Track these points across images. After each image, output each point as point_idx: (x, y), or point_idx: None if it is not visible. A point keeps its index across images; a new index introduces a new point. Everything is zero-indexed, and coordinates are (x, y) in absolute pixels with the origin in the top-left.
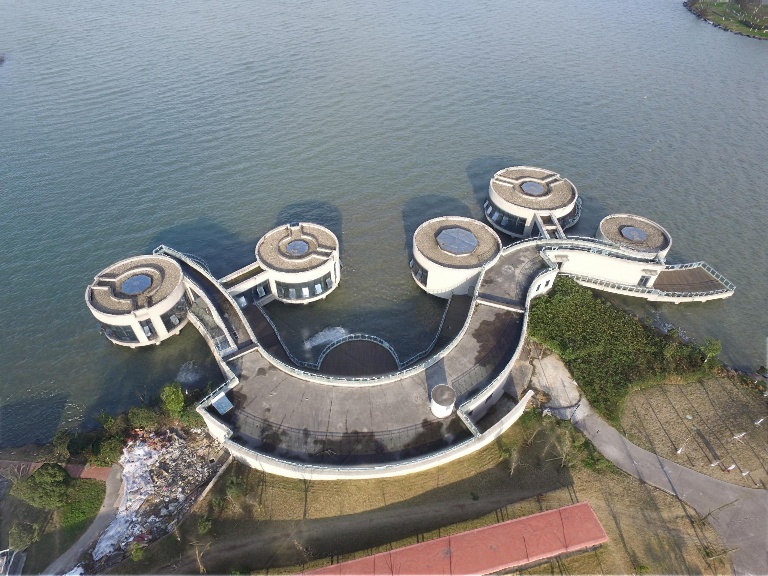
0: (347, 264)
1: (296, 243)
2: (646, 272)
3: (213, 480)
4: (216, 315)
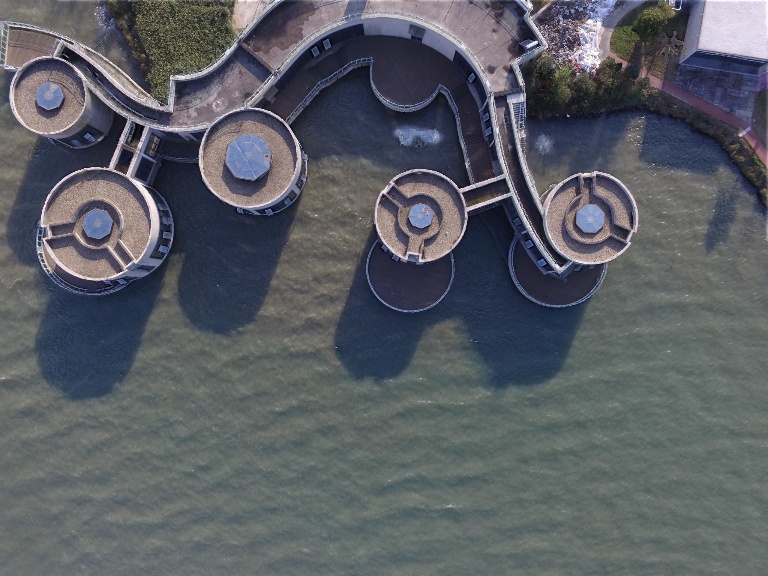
0: (364, 231)
1: (420, 224)
2: (83, 51)
3: (539, 12)
4: (520, 145)
